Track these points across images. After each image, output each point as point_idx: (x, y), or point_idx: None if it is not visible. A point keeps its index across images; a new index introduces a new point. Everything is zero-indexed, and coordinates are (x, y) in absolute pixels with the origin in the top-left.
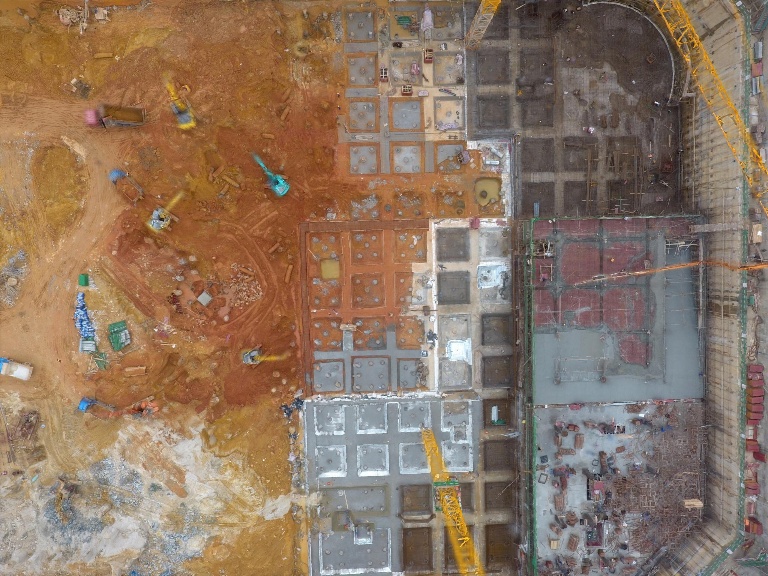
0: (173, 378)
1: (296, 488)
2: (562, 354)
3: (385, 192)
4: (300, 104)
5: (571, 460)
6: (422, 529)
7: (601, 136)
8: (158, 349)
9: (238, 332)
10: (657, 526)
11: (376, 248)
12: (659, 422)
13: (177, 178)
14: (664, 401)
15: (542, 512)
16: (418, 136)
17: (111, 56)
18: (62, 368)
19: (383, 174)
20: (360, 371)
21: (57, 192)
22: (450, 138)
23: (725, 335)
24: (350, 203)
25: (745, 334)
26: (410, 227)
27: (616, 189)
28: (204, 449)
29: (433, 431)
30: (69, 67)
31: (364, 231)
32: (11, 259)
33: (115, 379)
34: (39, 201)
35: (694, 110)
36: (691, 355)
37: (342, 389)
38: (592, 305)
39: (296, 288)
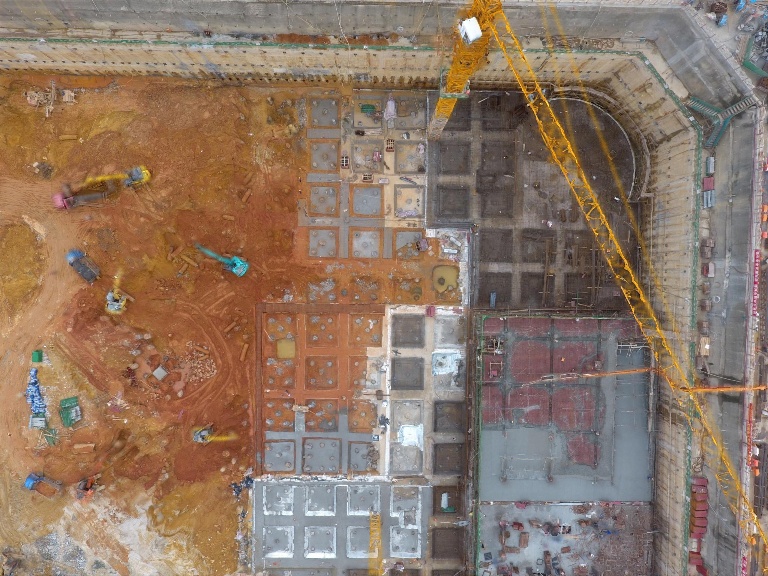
0: (122, 454)
1: (242, 566)
2: (509, 451)
3: (342, 276)
4: (262, 187)
5: (515, 558)
6: None
7: (560, 229)
8: (109, 425)
9: (191, 408)
10: None
11: (332, 330)
12: (606, 524)
13: (134, 260)
14: (611, 503)
15: None
16: (377, 222)
17: (75, 138)
18: (12, 442)
19: (341, 258)
20: (311, 452)
21: (16, 268)
22: (409, 225)
23: (672, 443)
24: (307, 285)
25: (690, 447)
26: (366, 311)
27: (573, 282)
28: (150, 527)
29: (382, 516)
30: (33, 149)
31: (320, 314)
32: None
33: (63, 456)
34: None
35: (652, 210)
36: (640, 457)
37: (292, 469)
38: (541, 403)
39: (251, 367)
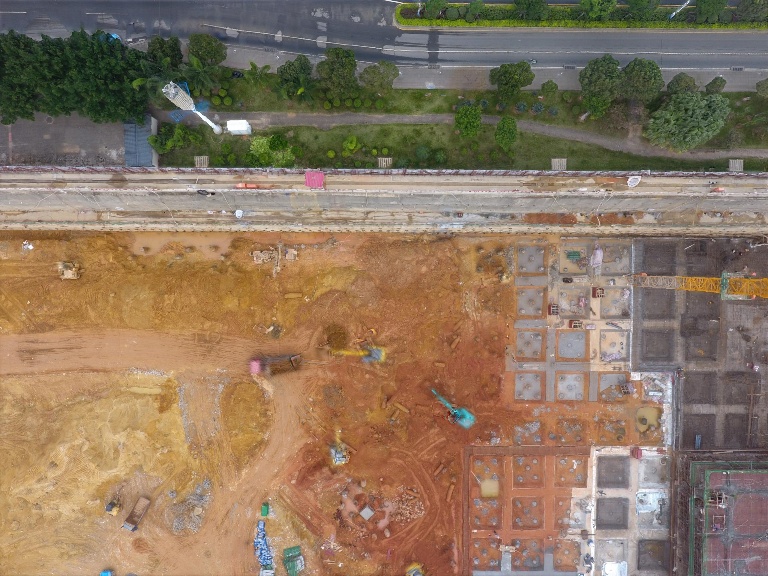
0: None
1: None
2: None
3: (549, 419)
4: (470, 334)
5: None
6: None
7: (763, 371)
8: (327, 570)
9: (398, 547)
10: None
11: (536, 471)
12: None
13: (358, 414)
14: None
15: None
16: (583, 366)
17: (300, 297)
18: None
19: (548, 402)
20: None
21: (242, 423)
22: (615, 369)
23: None
24: (514, 428)
25: None
26: (572, 453)
27: None
28: None
29: None
30: (263, 310)
31: (526, 455)
32: (198, 489)
33: None
34: (225, 432)
35: None
36: None
37: None
38: (762, 554)
39: (456, 507)
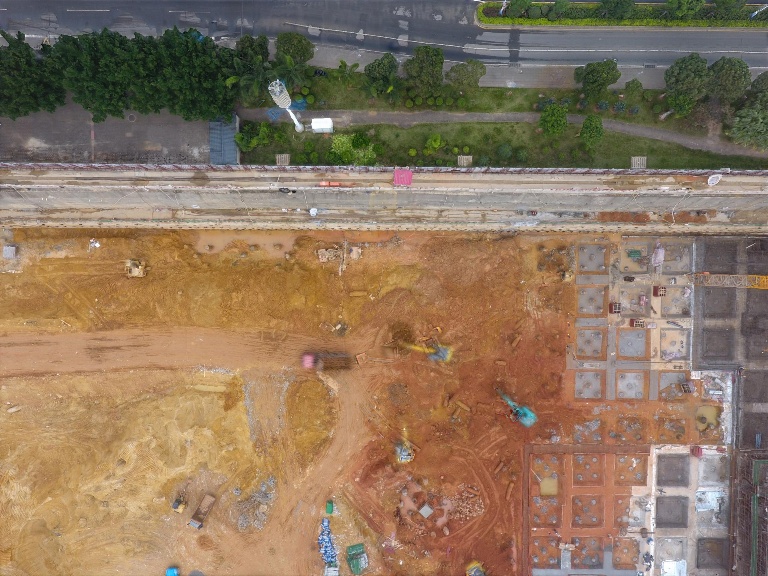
0: None
1: None
2: None
3: (609, 418)
4: (531, 332)
5: None
6: None
7: None
8: (388, 568)
9: (458, 545)
10: None
11: (596, 469)
12: None
13: (422, 412)
14: None
15: None
16: (644, 365)
17: (365, 295)
18: None
19: (608, 400)
20: None
21: (307, 421)
22: (675, 368)
23: None
24: (574, 426)
25: None
26: (631, 452)
27: None
28: None
29: None
30: (329, 308)
31: (586, 454)
32: (263, 487)
33: None
34: (290, 430)
35: None
36: None
37: None
38: None
39: (516, 505)
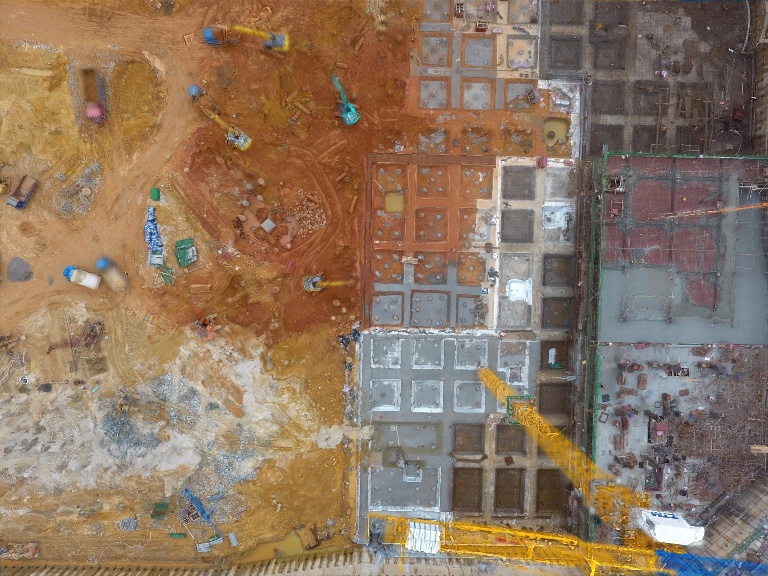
0: (235, 299)
1: (348, 420)
2: (629, 292)
3: (454, 127)
4: (375, 35)
5: (633, 401)
6: (472, 470)
7: (673, 81)
8: (222, 270)
9: (300, 260)
10: (718, 474)
11: (441, 183)
12: (724, 367)
13: (253, 98)
14: (731, 345)
15: (601, 452)
16: (490, 73)
17: None
18: (129, 281)
19: (453, 109)
20: (419, 306)
21: (135, 107)
22: (521, 76)
23: None
24: (418, 136)
25: None
26: (477, 163)
27: (686, 135)
28: (262, 372)
29: None
30: None
31: (431, 165)
32: (87, 169)
33: (180, 294)
34: (117, 115)
35: None
36: (760, 300)
37: (400, 323)
38: (661, 244)
39: (360, 219)
